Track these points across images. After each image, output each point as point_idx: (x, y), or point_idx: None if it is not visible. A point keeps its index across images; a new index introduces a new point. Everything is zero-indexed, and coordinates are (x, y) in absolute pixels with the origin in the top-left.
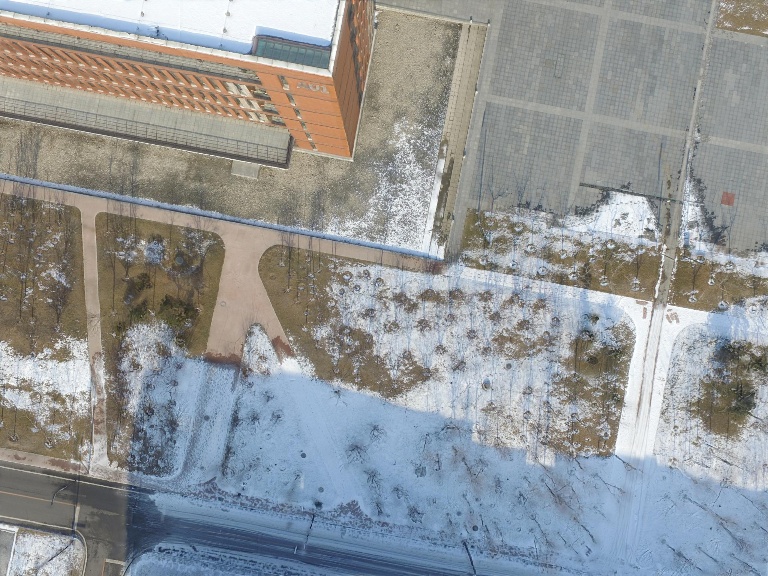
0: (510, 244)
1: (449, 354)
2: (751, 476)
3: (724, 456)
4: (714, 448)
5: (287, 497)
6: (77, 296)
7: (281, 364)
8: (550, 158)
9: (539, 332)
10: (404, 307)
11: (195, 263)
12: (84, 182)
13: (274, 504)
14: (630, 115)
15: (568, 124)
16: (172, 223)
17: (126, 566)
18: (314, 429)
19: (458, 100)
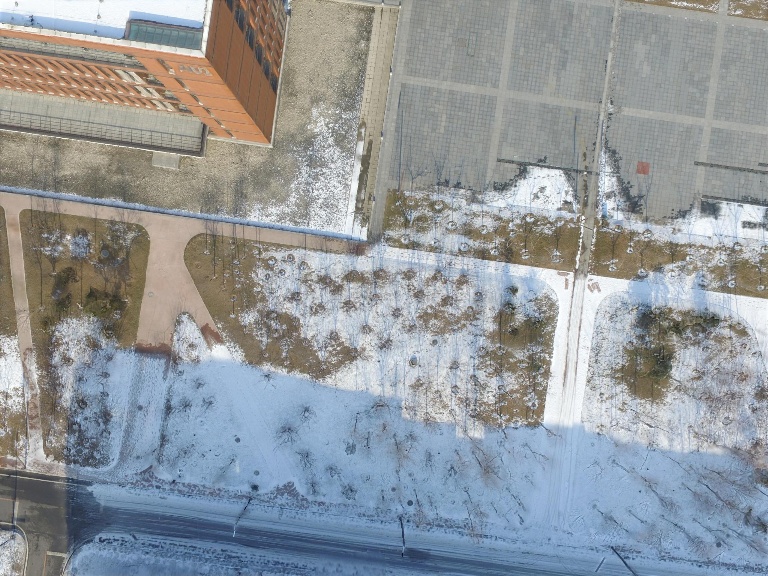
0: (431, 222)
1: (375, 333)
2: (677, 438)
3: (649, 420)
4: (636, 412)
5: (223, 482)
6: (5, 293)
7: (211, 351)
8: (467, 136)
9: (463, 307)
10: (329, 289)
11: (121, 255)
12: (7, 180)
13: (211, 489)
14: (543, 90)
15: (483, 101)
16: (96, 217)
17: (67, 558)
18: (247, 413)
19: (374, 82)
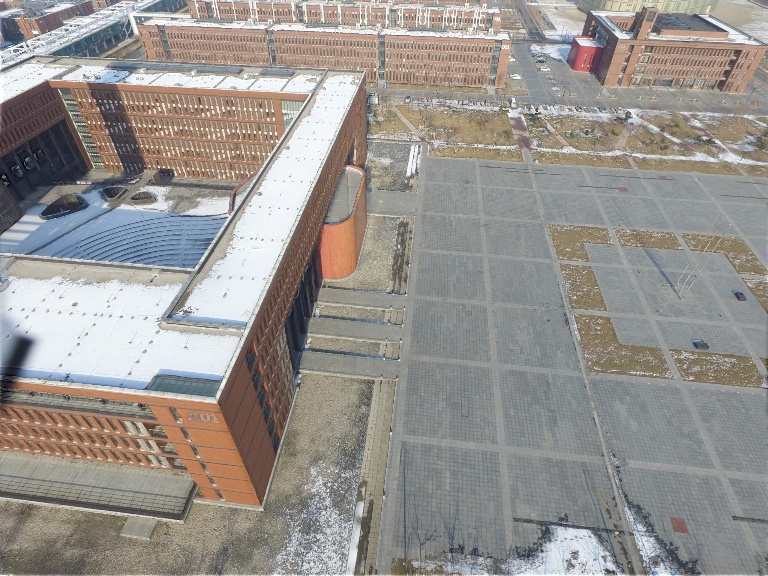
0: None
1: None
2: None
3: None
4: None
5: None
6: None
7: None
8: (475, 493)
9: None
10: None
11: None
12: None
13: None
14: (542, 445)
15: (485, 457)
16: None
17: None
18: None
19: (374, 441)
